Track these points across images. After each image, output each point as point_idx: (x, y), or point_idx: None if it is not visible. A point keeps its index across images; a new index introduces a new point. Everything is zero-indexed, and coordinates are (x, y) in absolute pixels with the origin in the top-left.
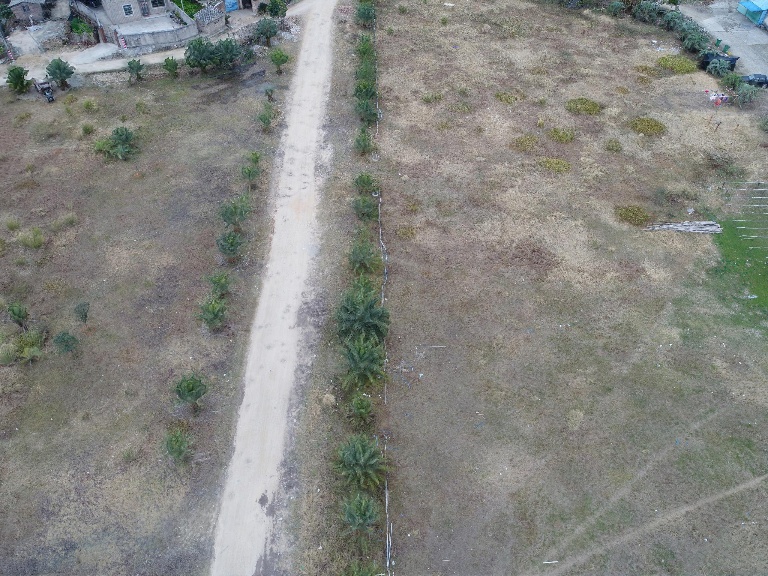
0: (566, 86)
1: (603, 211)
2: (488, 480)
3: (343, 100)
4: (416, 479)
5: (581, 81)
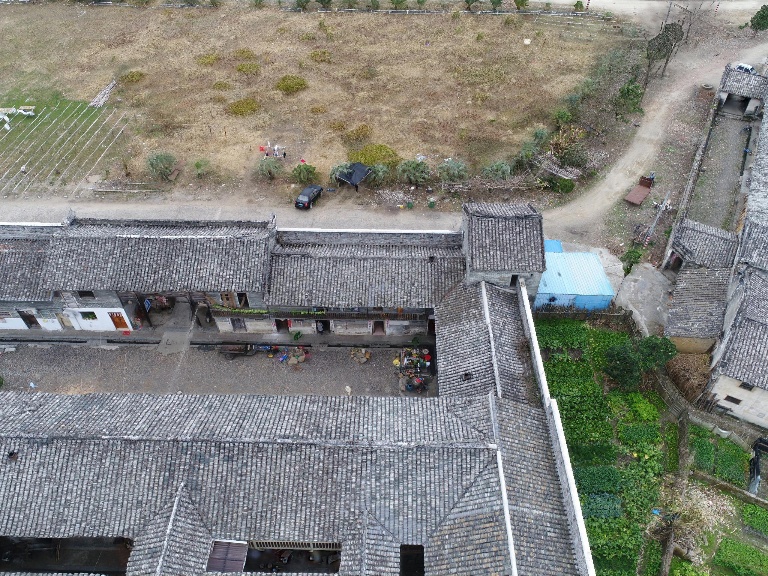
0: (335, 84)
1: (145, 68)
2: (6, 19)
3: (335, 3)
4: (22, 8)
5: (344, 92)
